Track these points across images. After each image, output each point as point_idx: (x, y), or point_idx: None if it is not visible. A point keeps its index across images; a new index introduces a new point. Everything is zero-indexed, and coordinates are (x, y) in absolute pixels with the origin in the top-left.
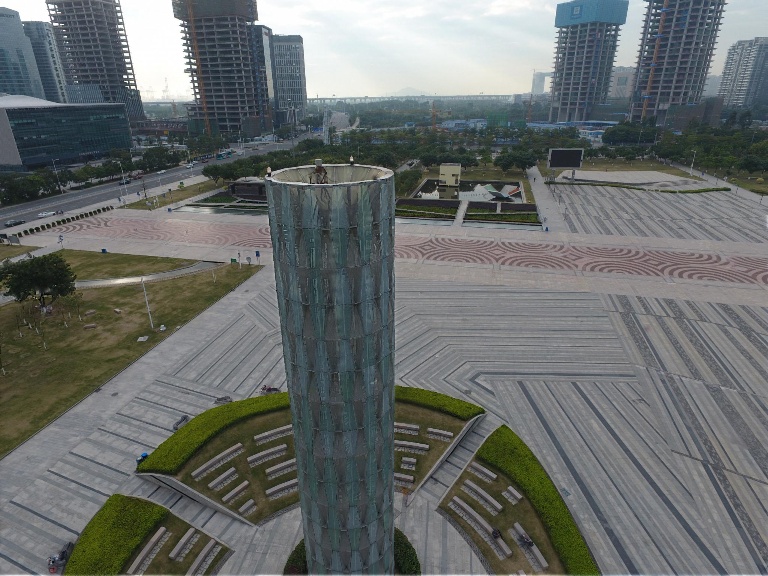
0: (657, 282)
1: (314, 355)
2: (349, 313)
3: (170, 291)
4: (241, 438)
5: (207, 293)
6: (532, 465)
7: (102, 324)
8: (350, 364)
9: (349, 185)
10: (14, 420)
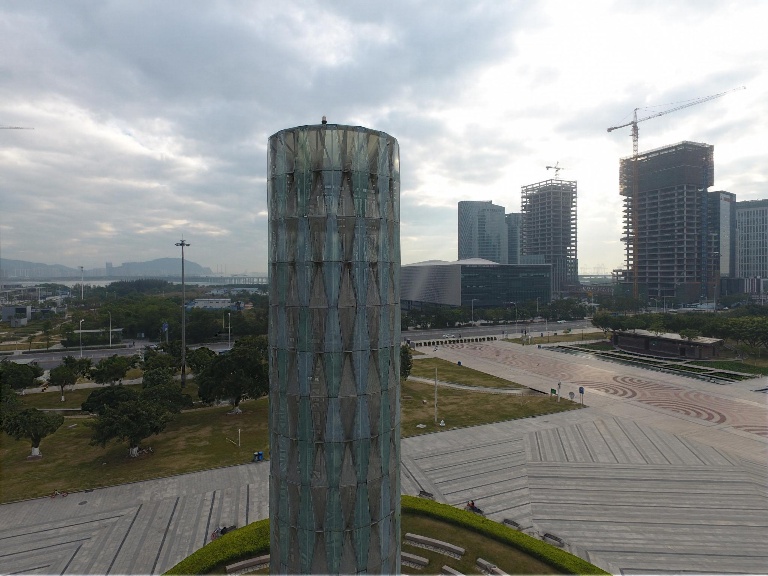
0: None
1: None
2: (286, 273)
3: (477, 401)
4: None
5: (506, 412)
6: None
7: (407, 407)
8: (286, 340)
9: (291, 129)
10: None
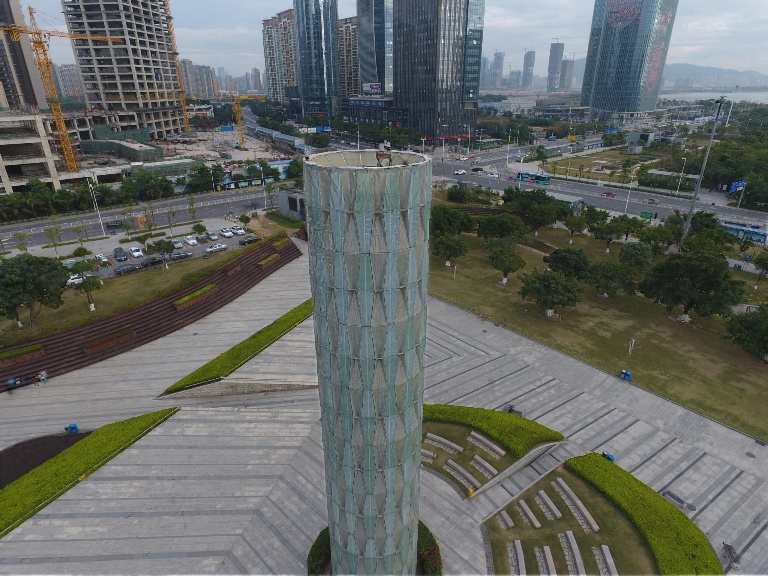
0: None
1: None
2: None
3: None
4: (609, 533)
5: None
6: None
7: None
8: None
9: None
10: (697, 390)
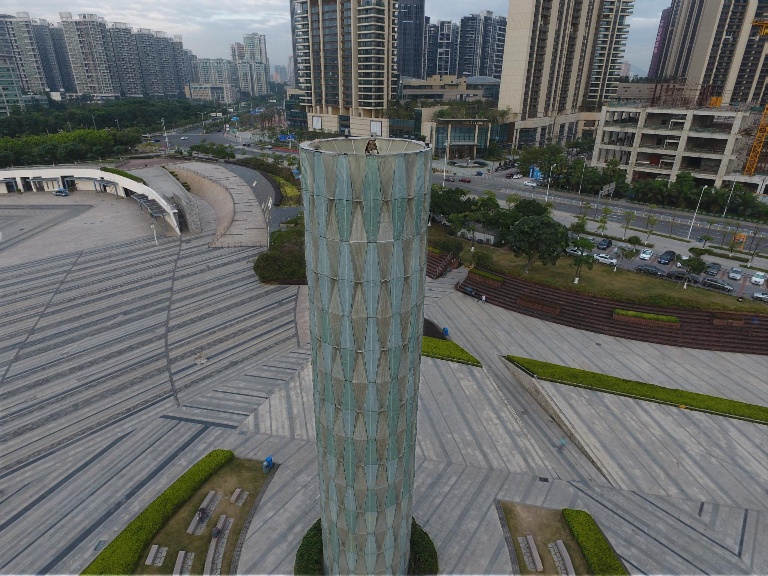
0: None
1: None
2: None
3: None
4: None
5: None
6: None
7: None
8: None
9: None
10: None
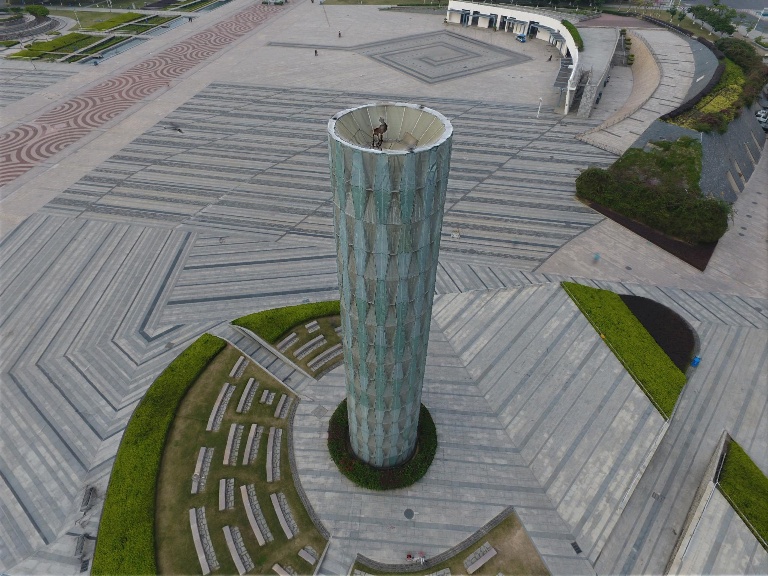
0: (45, 172)
1: (435, 267)
2: None
3: None
4: None
5: None
6: (284, 311)
7: None
8: None
9: None
10: None
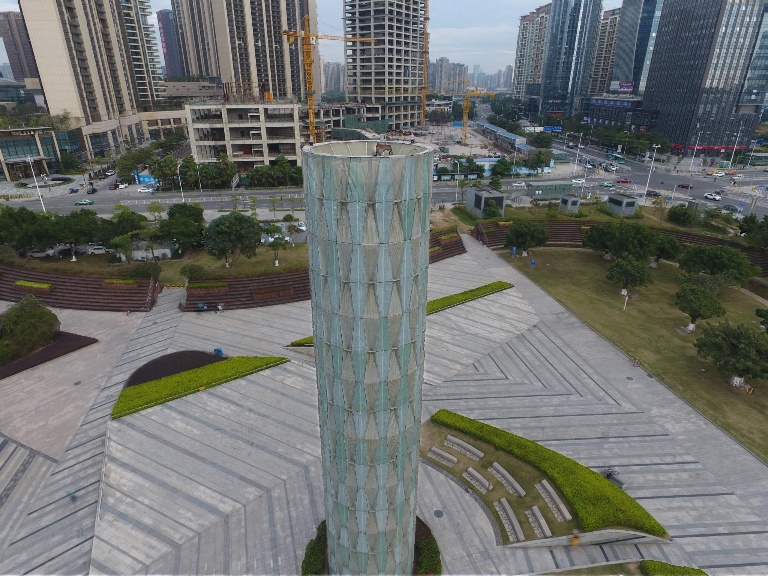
0: None
1: None
2: None
3: None
4: None
5: None
6: None
7: None
8: None
9: None
10: None
